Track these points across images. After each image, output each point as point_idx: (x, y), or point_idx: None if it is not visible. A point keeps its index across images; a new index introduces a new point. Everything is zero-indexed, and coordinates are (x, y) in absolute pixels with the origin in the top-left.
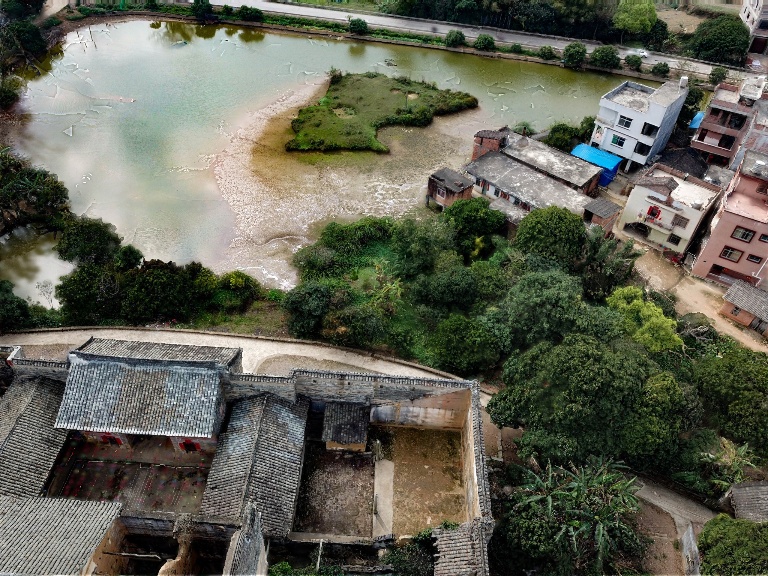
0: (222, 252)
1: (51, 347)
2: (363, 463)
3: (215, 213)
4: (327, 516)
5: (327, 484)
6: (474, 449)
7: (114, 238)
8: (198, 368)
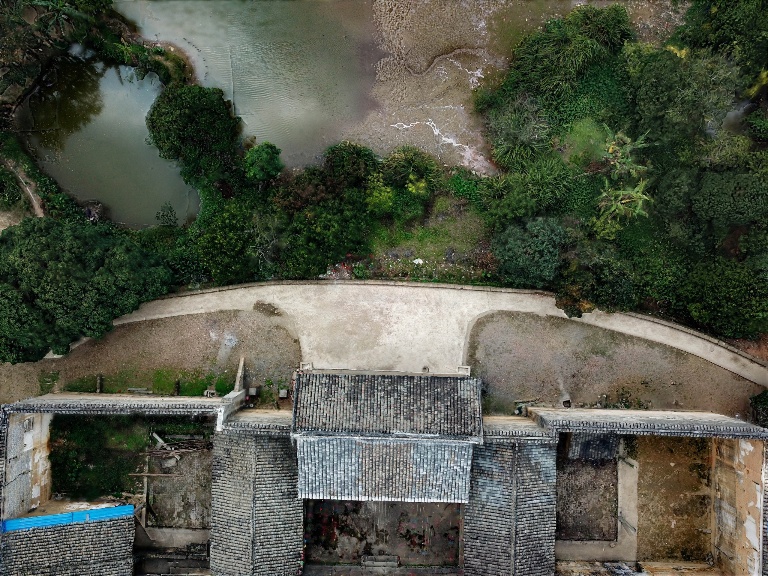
0: (368, 93)
1: (215, 316)
2: (604, 461)
3: (338, 0)
4: (572, 521)
5: (569, 487)
6: (763, 527)
7: (227, 121)
8: (447, 441)
